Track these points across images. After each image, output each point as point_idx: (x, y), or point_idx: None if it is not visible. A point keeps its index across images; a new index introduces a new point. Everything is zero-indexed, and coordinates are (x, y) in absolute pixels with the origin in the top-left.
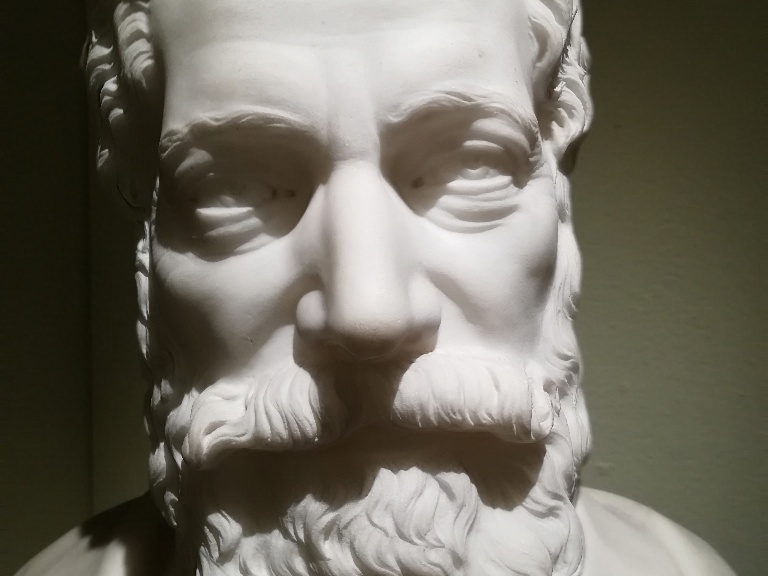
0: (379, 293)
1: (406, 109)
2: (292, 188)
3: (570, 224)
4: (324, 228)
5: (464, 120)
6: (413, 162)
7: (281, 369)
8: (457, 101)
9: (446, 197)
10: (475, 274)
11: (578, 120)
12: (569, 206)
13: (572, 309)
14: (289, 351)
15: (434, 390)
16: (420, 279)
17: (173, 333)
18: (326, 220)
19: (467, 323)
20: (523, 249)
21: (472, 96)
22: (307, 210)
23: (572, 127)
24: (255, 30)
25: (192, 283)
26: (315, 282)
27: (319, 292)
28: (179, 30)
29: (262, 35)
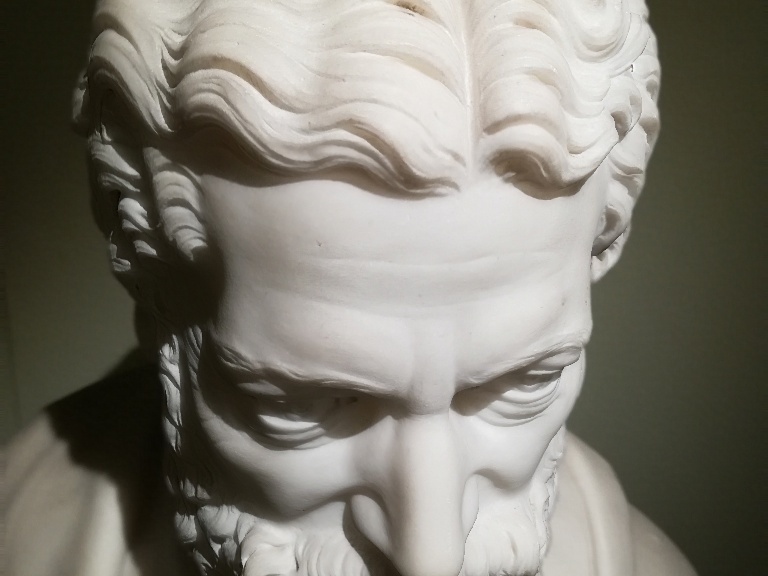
0: (447, 552)
1: (488, 375)
2: (355, 396)
3: None
4: (394, 469)
5: None
6: None
7: (331, 538)
8: (535, 358)
9: (499, 402)
10: (512, 463)
11: (617, 252)
12: None
13: None
14: (339, 522)
15: (467, 571)
16: (468, 484)
17: (212, 457)
18: (397, 464)
19: (494, 488)
20: (554, 428)
21: (549, 349)
22: (373, 433)
23: (610, 260)
24: (346, 297)
25: (247, 460)
26: (376, 497)
27: (381, 511)
28: (249, 253)
29: (353, 303)
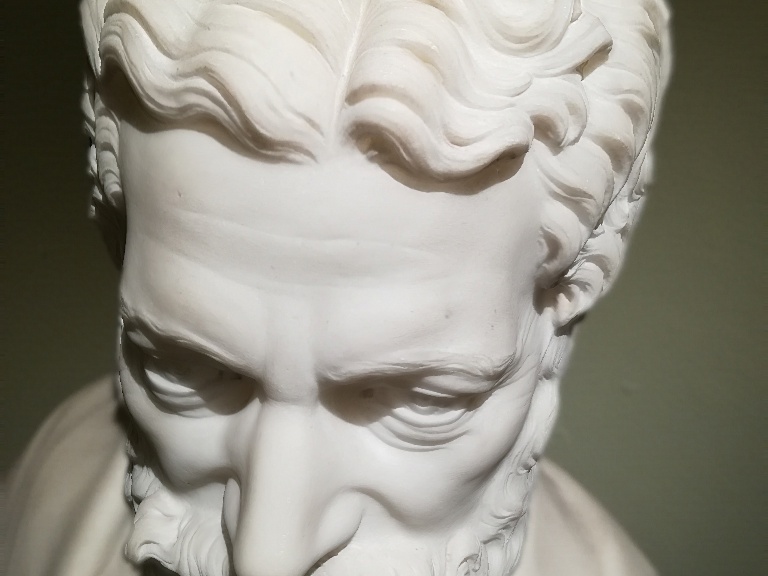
0: (276, 555)
1: (346, 373)
2: None
3: (557, 379)
4: (249, 454)
5: (415, 374)
6: (362, 382)
7: (209, 520)
8: (405, 369)
9: (390, 418)
10: (403, 491)
11: (591, 296)
12: (563, 357)
13: (529, 466)
14: (220, 505)
15: None
16: (342, 498)
17: None
18: (251, 449)
19: (391, 518)
20: (463, 468)
21: (425, 363)
22: (243, 413)
23: (581, 302)
24: (201, 254)
25: (142, 417)
26: None
27: (239, 498)
28: (136, 198)
29: (207, 262)
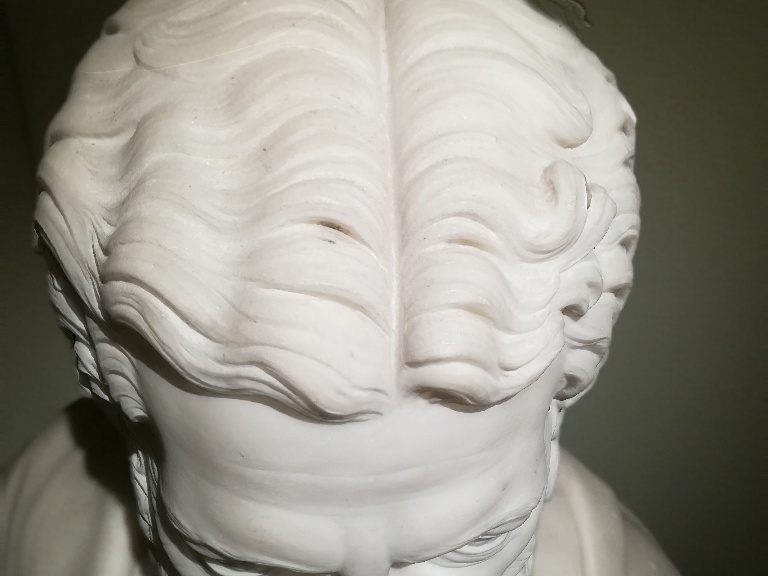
0: None
1: None
2: None
3: None
4: None
5: None
6: None
7: None
8: None
9: None
10: None
11: None
12: None
13: None
14: None
15: None
16: None
17: None
18: None
19: None
20: None
21: (488, 529)
22: None
23: None
24: (272, 499)
25: None
26: None
27: None
28: (181, 443)
29: (279, 504)
